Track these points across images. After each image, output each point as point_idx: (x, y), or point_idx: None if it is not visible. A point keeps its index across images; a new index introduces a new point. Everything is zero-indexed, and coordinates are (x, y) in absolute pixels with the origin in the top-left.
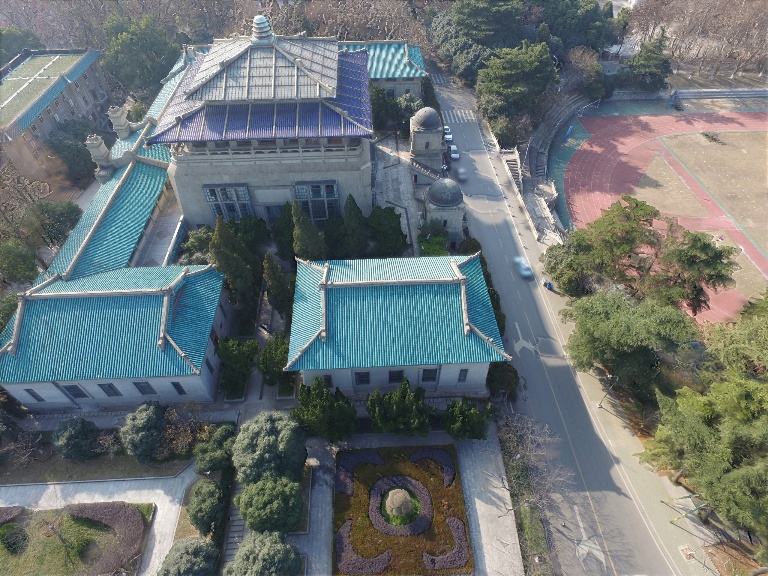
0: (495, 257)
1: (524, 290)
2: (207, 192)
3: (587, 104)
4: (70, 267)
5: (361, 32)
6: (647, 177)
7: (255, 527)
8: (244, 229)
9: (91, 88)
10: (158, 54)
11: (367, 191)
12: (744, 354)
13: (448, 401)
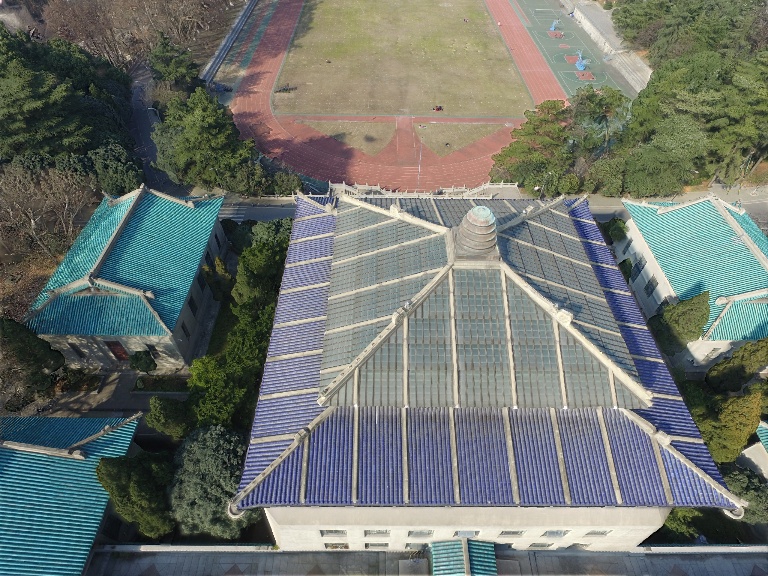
0: None
1: None
2: None
3: None
4: None
5: None
6: (336, 136)
7: None
8: None
9: None
10: None
11: None
12: None
13: None
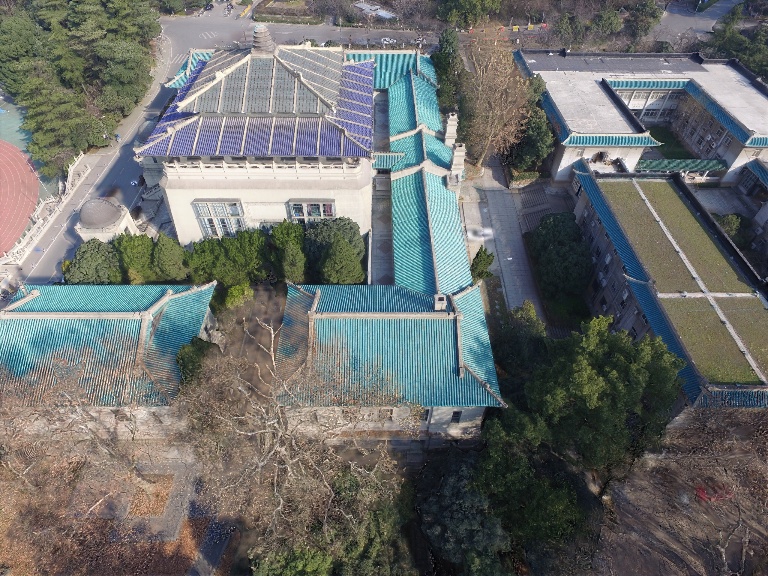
0: None
1: None
2: None
3: None
4: None
5: None
6: None
7: None
8: None
9: None
10: None
11: None
12: None
13: None
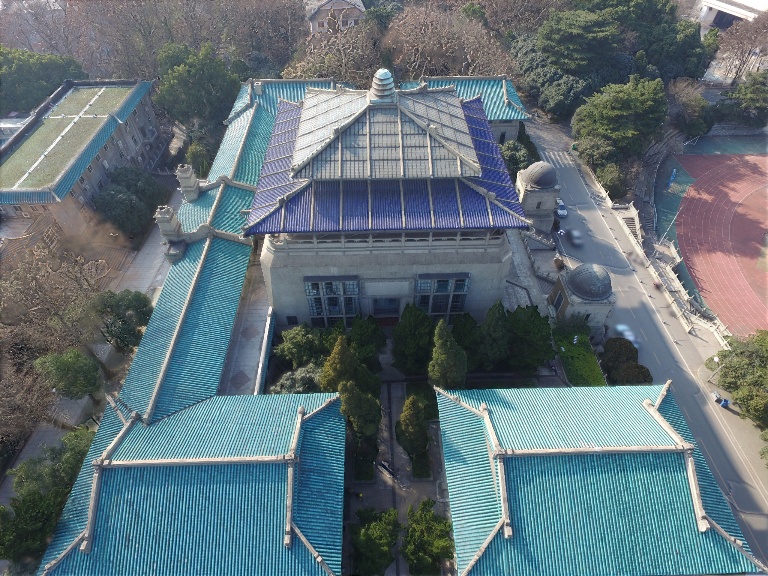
0: (642, 356)
1: (691, 407)
2: (308, 286)
3: (682, 140)
4: (152, 404)
5: (433, 58)
6: None
7: None
8: (360, 339)
9: (140, 125)
10: (214, 85)
11: (502, 283)
12: None
13: None
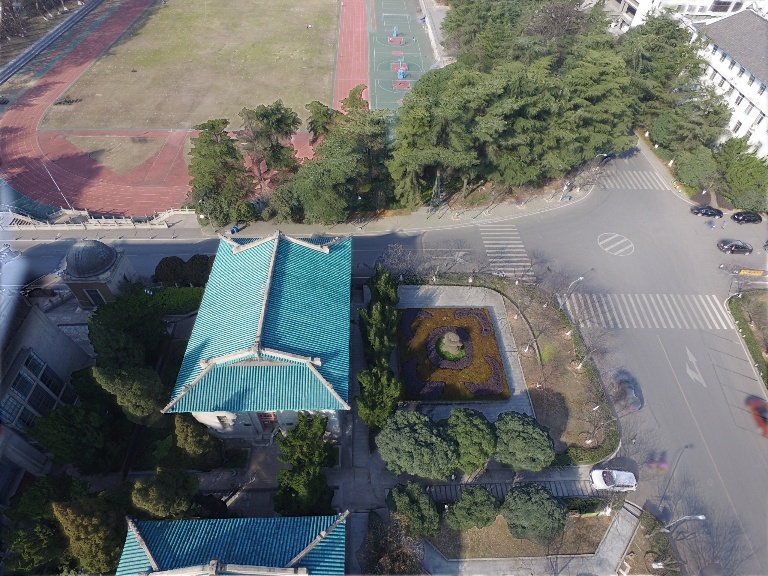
0: None
1: None
2: None
3: None
4: None
5: None
6: (92, 153)
7: (495, 443)
8: None
9: None
10: None
11: None
12: (377, 120)
13: (353, 313)
